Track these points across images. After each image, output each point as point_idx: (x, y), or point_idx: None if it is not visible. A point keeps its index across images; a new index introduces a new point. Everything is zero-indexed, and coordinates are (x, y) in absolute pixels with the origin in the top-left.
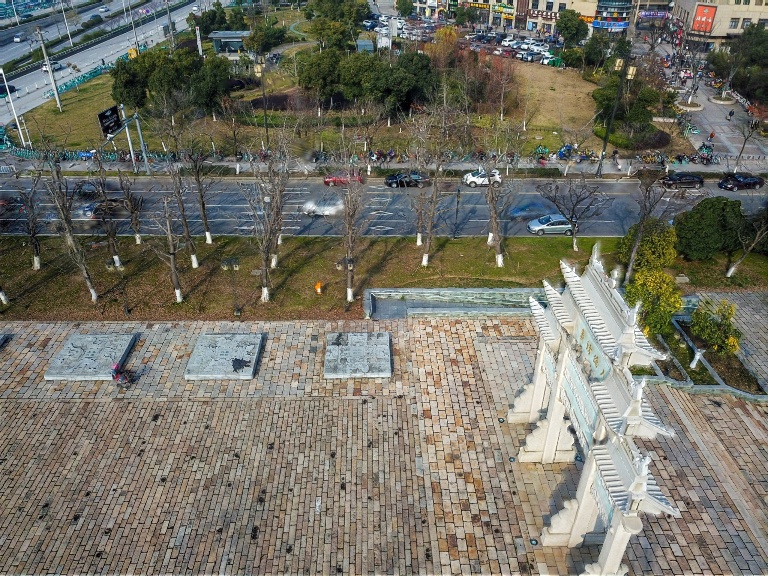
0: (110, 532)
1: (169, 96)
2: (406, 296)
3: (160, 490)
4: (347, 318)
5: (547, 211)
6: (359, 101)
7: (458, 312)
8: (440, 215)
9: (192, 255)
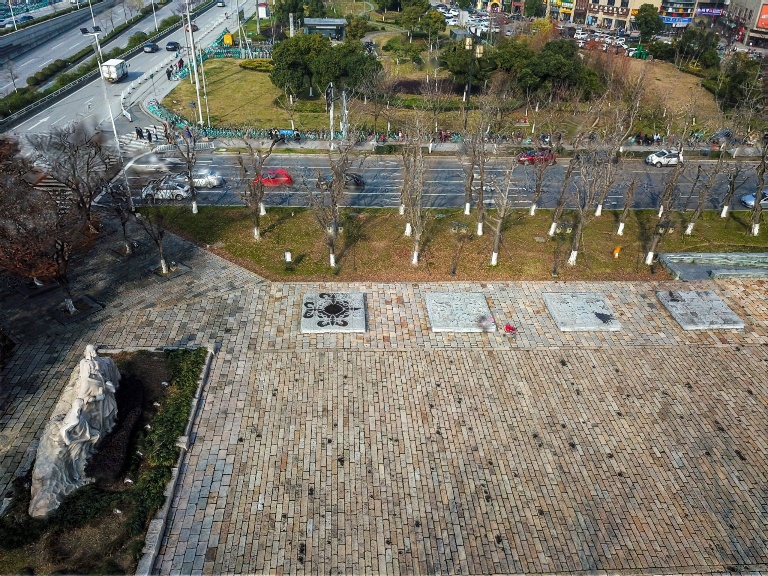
0: (613, 456)
1: None
2: (696, 260)
3: (625, 422)
4: (658, 279)
5: (744, 189)
6: (552, 84)
7: (760, 273)
8: (650, 192)
9: (480, 223)
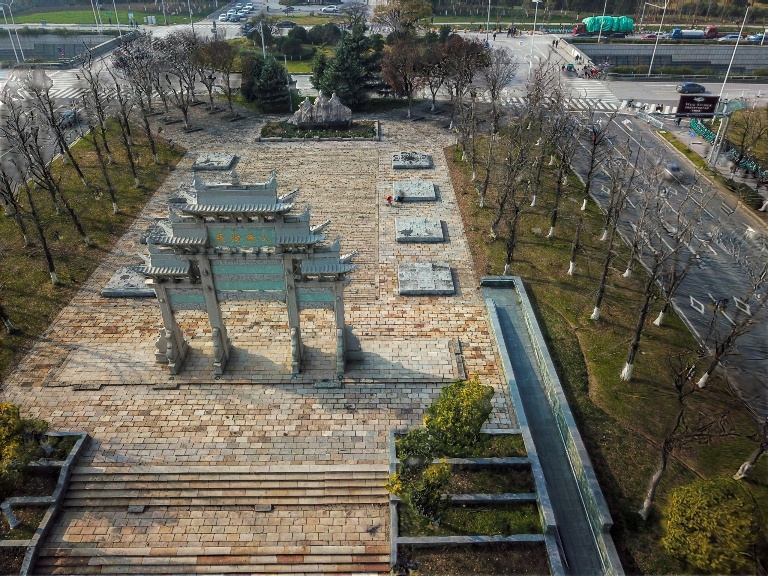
0: None
1: (765, 107)
2: None
3: None
4: (479, 274)
5: None
6: None
7: None
8: None
9: None
